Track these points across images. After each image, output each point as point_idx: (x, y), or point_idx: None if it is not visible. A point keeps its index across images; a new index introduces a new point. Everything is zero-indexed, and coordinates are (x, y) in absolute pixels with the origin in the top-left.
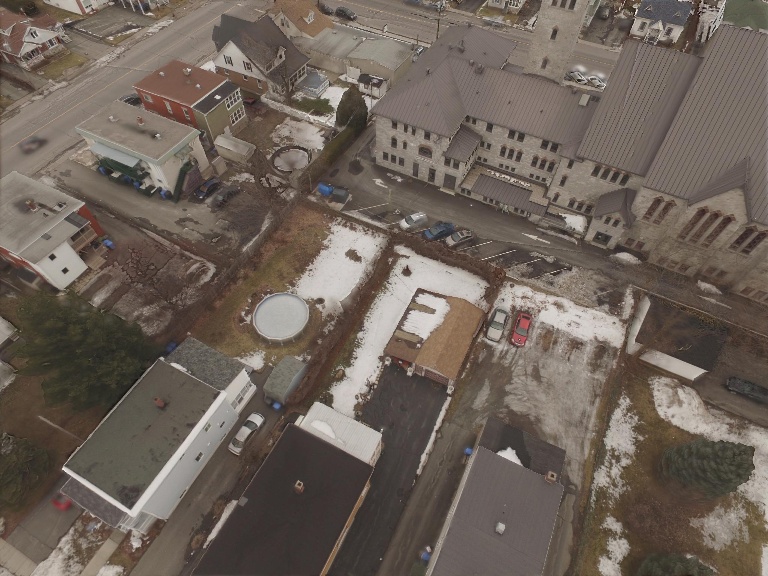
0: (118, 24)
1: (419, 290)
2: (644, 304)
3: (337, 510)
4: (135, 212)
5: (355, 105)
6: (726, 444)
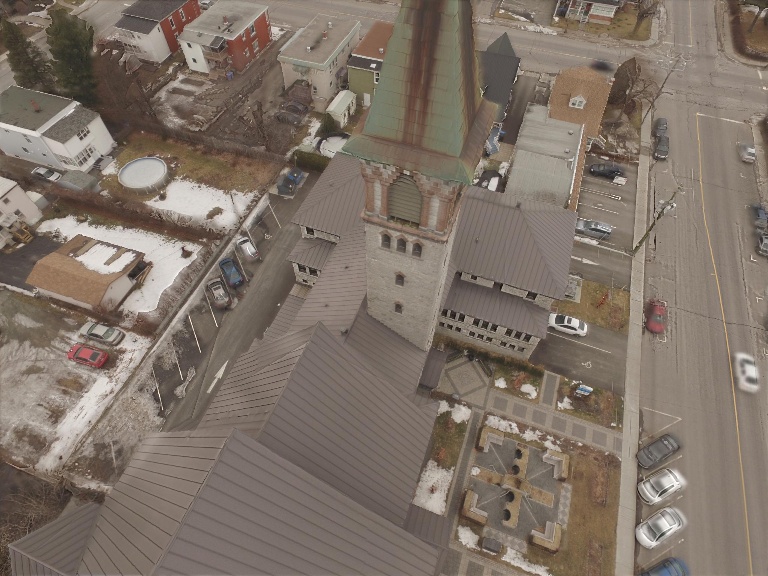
0: (520, 6)
1: (141, 254)
2: None
3: None
4: (268, 80)
5: None
6: None
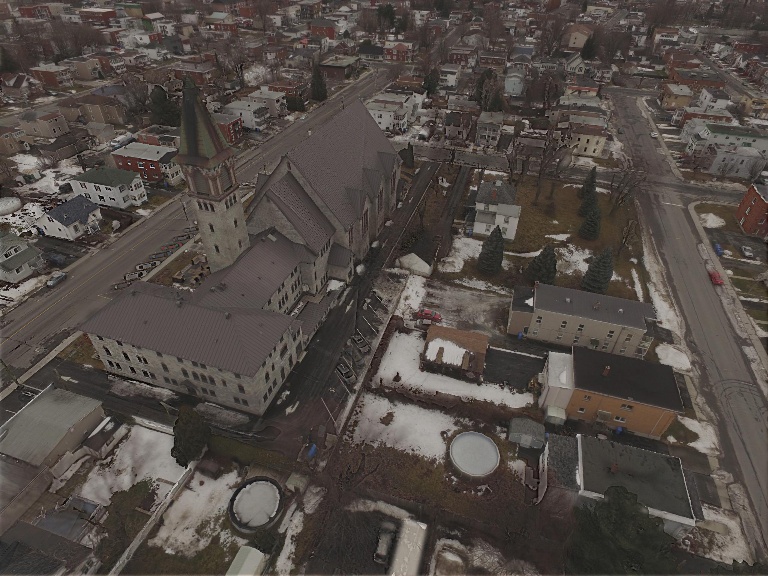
0: None
1: (423, 359)
2: (411, 257)
3: (603, 357)
4: None
5: (198, 418)
6: (493, 236)
